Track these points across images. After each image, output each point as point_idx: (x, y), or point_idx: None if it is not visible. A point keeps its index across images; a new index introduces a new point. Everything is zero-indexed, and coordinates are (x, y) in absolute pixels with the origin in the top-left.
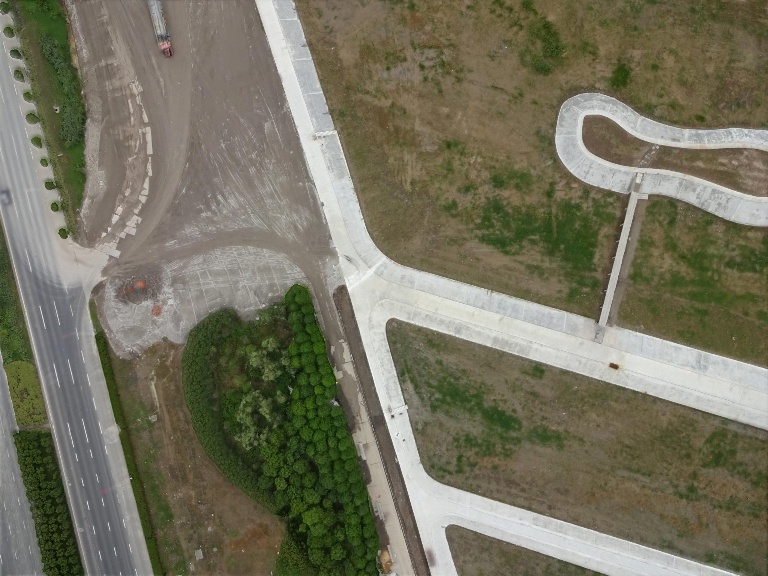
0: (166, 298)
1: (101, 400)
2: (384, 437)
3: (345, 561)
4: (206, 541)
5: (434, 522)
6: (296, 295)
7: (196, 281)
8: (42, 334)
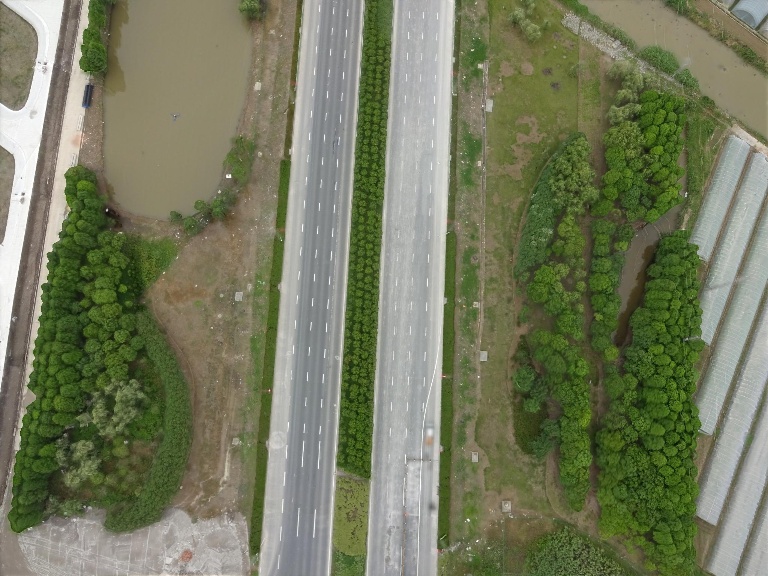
0: (171, 567)
1: (277, 480)
2: (19, 344)
3: (93, 247)
4: (228, 306)
5: (5, 253)
6: (13, 522)
7: (133, 574)
8: (316, 575)
